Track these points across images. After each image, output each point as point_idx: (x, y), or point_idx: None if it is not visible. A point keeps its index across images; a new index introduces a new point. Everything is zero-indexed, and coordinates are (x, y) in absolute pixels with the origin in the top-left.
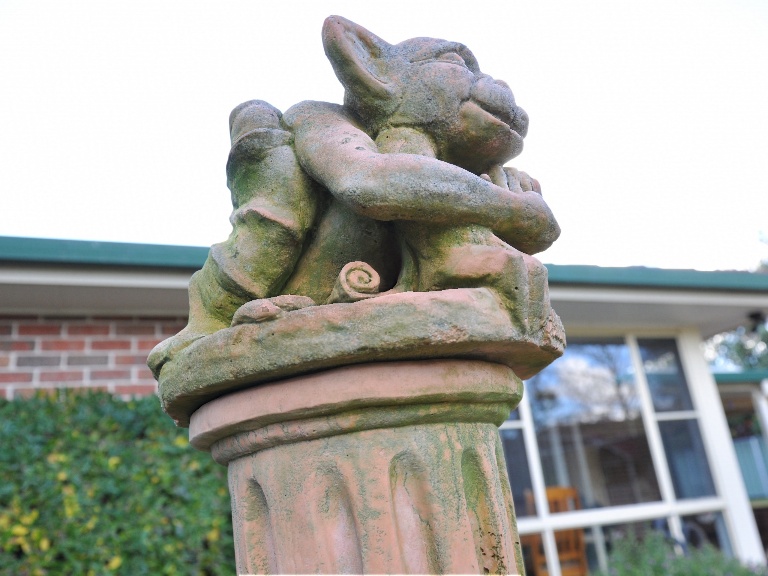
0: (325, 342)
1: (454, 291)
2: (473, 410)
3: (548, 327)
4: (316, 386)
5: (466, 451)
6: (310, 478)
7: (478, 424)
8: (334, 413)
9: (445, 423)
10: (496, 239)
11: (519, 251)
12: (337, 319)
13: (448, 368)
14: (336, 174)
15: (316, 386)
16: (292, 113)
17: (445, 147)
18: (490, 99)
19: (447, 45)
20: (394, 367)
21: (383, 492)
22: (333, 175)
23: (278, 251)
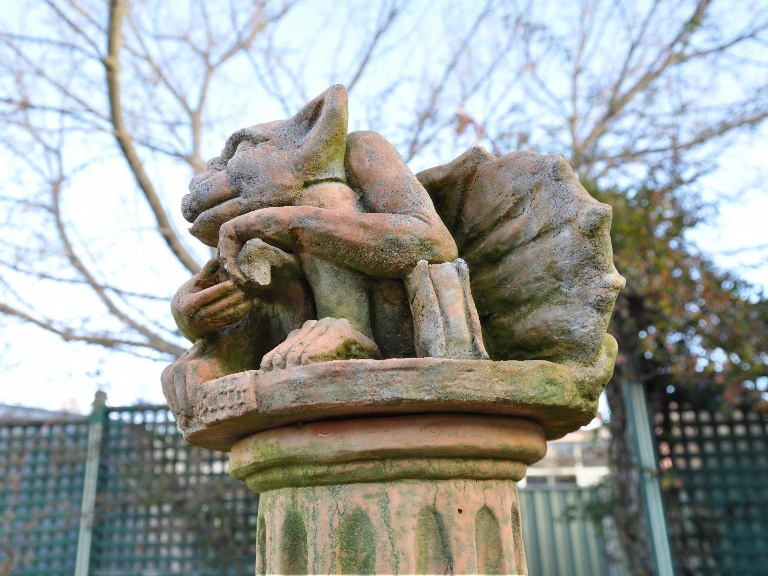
0: None
1: None
2: None
3: None
4: None
5: None
6: None
7: None
8: None
9: None
10: None
11: None
12: None
13: None
14: None
15: None
16: None
17: None
18: None
19: None
20: None
21: None
22: None
23: None
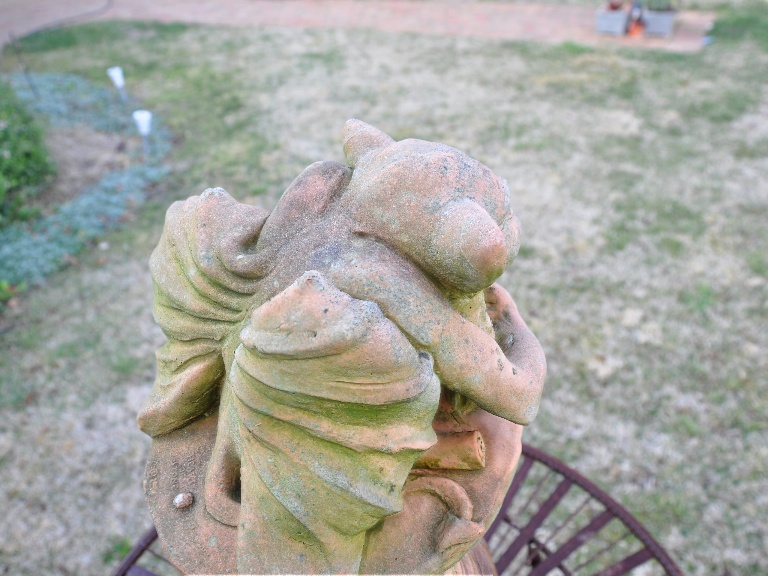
0: None
1: None
2: None
3: None
4: None
5: None
6: None
7: None
8: None
9: None
10: None
11: None
12: None
13: None
14: (511, 408)
15: None
16: (420, 325)
17: None
18: None
19: None
20: None
21: None
22: (507, 408)
23: None
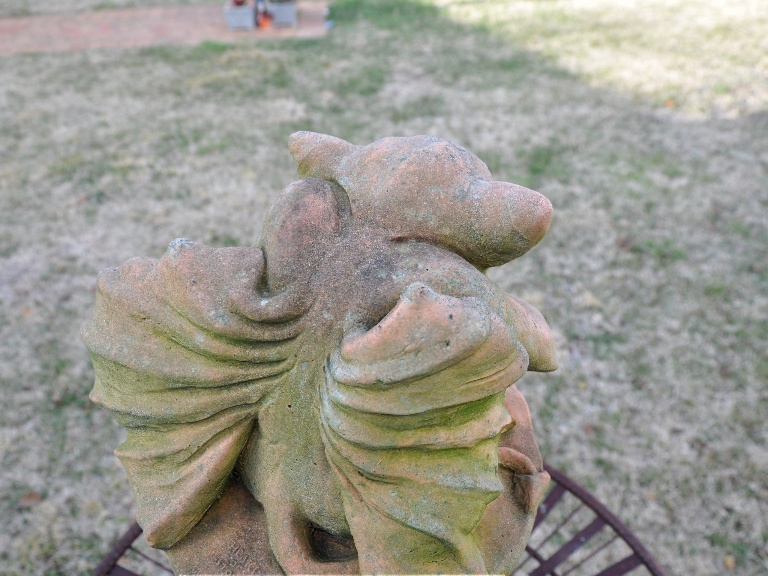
0: None
1: None
2: None
3: None
4: None
5: None
6: None
7: None
8: None
9: None
10: None
11: None
12: None
13: None
14: None
15: None
16: None
17: None
18: None
19: None
20: None
21: None
22: None
23: None
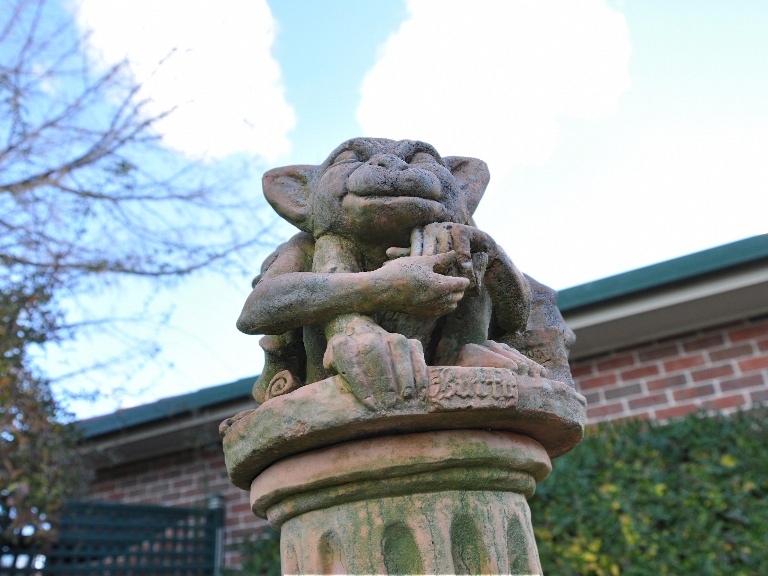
0: (238, 449)
1: (302, 388)
2: (388, 485)
3: (432, 391)
4: (260, 481)
5: (395, 525)
6: (285, 554)
7: (415, 495)
8: (278, 501)
9: (368, 500)
10: (352, 324)
11: (362, 331)
12: (241, 430)
13: (340, 452)
14: None
15: (260, 481)
16: None
17: (355, 238)
18: (357, 186)
19: (337, 149)
20: (298, 459)
21: (313, 567)
22: None
23: (274, 368)
